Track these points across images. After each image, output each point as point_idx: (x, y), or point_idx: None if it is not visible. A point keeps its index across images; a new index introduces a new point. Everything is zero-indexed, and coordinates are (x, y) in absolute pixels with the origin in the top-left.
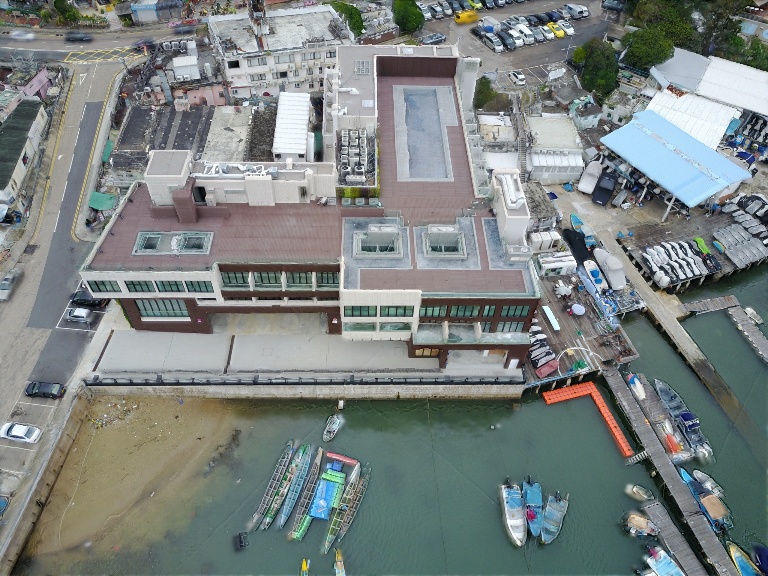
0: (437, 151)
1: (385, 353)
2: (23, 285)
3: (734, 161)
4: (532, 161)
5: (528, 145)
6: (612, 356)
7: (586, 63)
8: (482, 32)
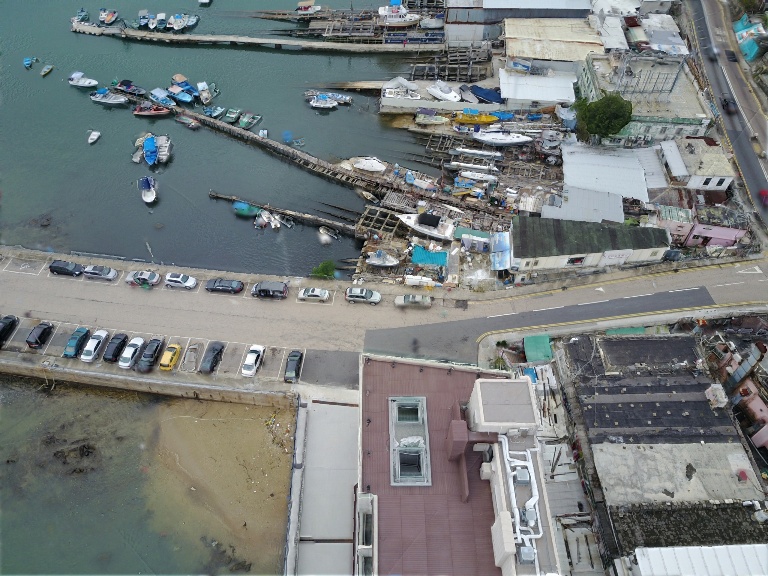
0: None
1: None
2: (415, 312)
3: None
4: None
5: None
6: None
7: None
8: None
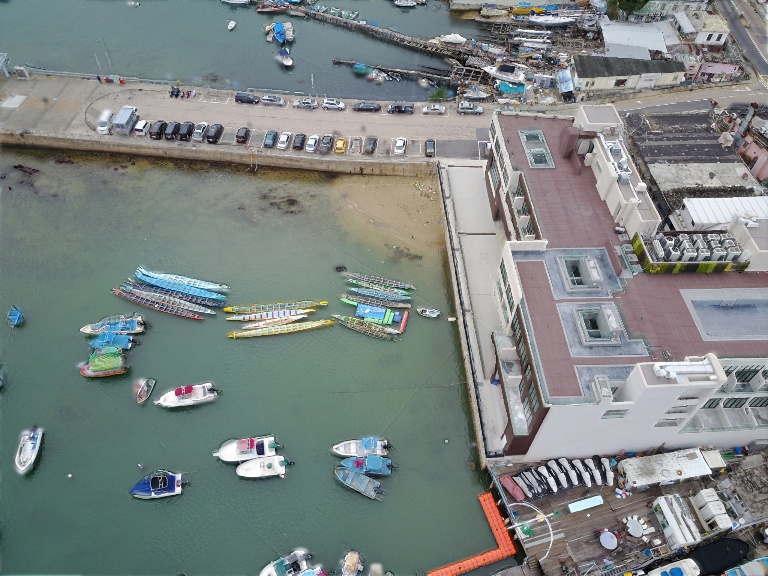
0: (760, 333)
1: None
2: None
3: None
4: None
5: None
6: (549, 574)
7: None
8: None
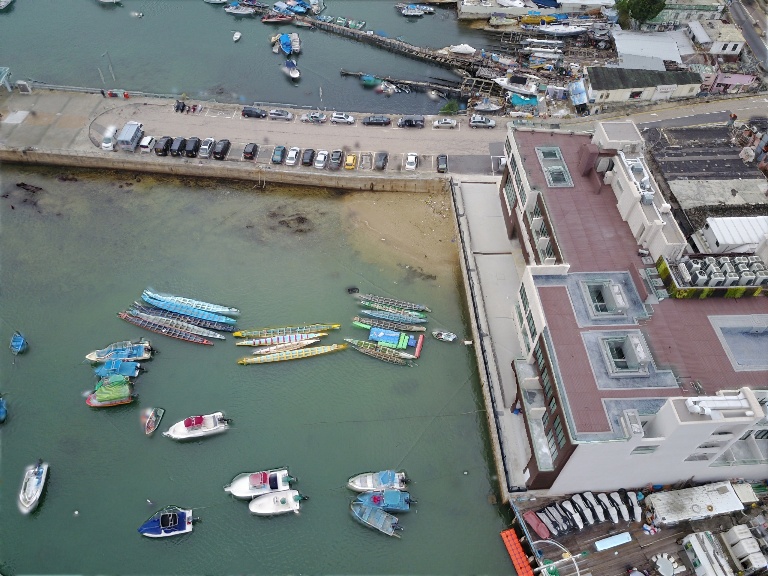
0: None
1: None
2: None
3: None
4: None
5: None
6: None
7: None
8: None
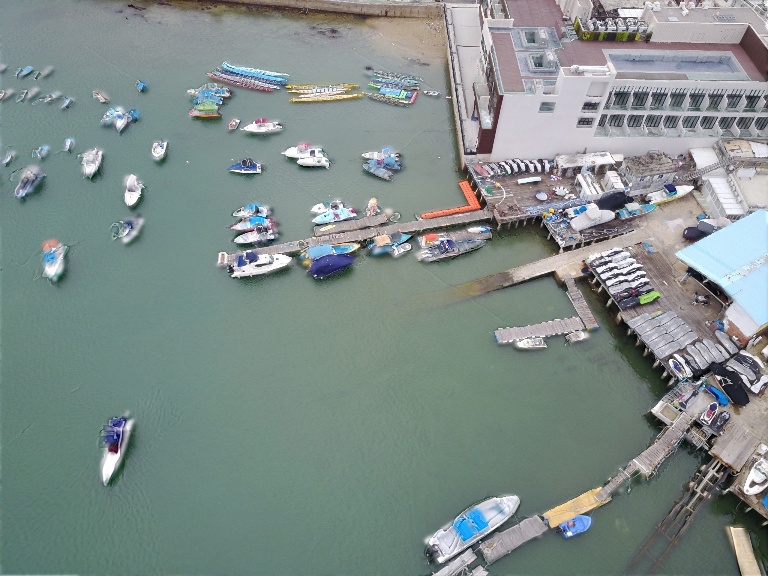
0: None
1: None
2: None
3: None
4: (715, 178)
5: (732, 169)
6: (500, 211)
7: None
8: None
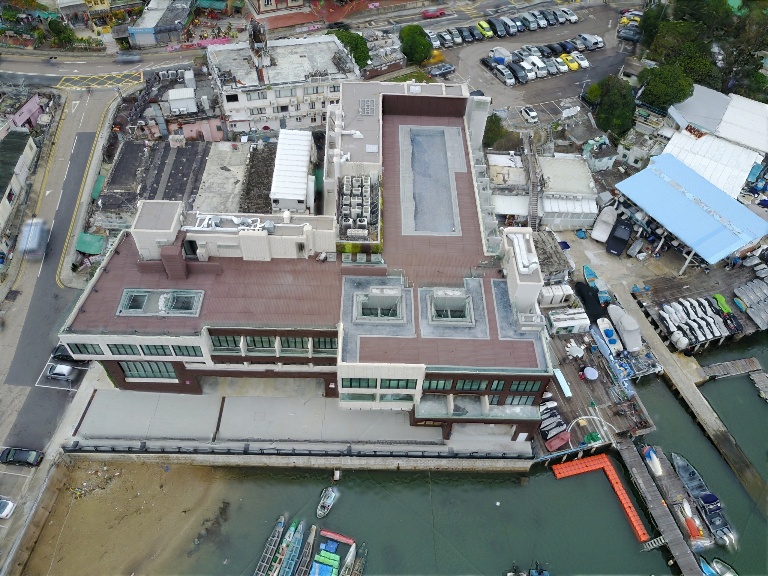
0: (444, 200)
1: (385, 420)
2: (2, 336)
3: (756, 210)
4: (544, 206)
5: (540, 189)
6: (627, 427)
7: (601, 101)
8: (493, 63)
